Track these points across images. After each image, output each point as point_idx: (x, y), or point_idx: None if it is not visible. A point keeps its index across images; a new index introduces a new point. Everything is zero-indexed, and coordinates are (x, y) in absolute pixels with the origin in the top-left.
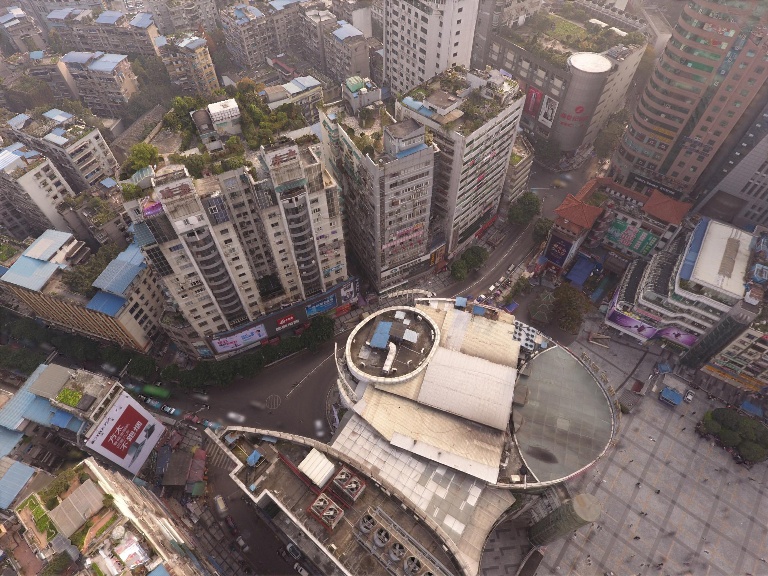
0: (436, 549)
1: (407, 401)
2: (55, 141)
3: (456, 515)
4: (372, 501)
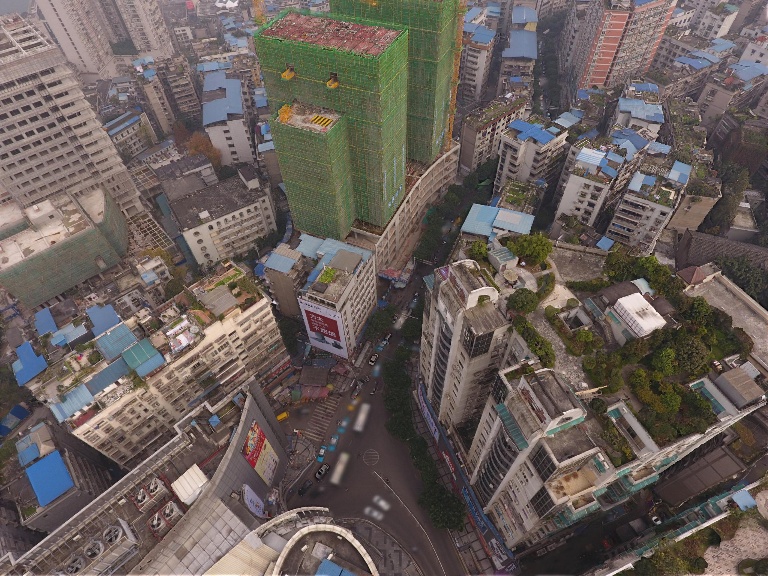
0: None
1: None
2: (633, 182)
3: None
4: (147, 545)
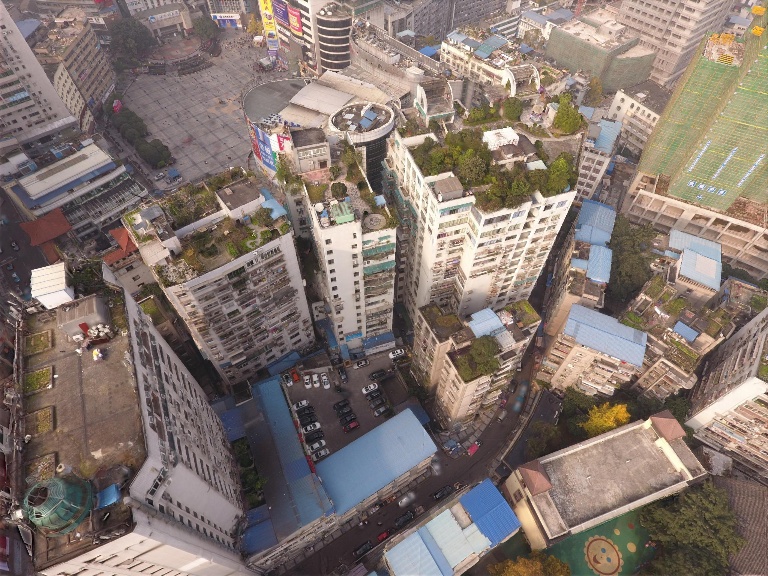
0: None
1: None
2: None
3: (350, 69)
4: None
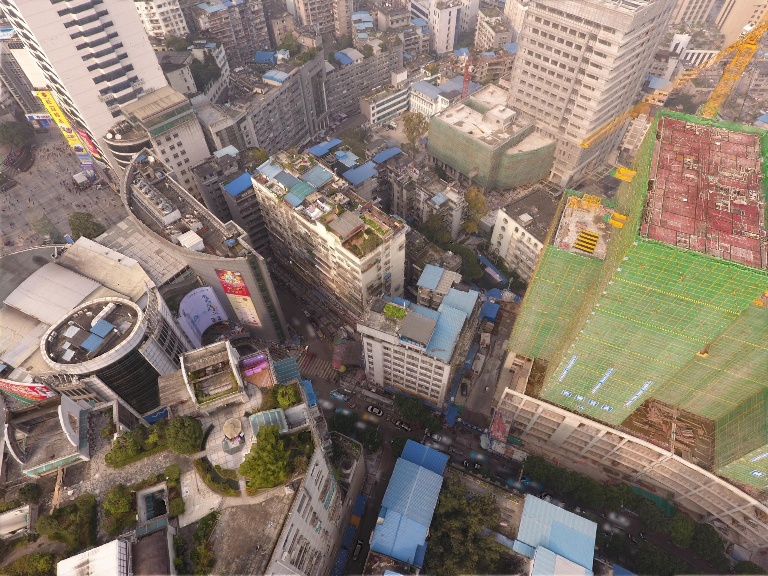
0: (138, 210)
1: (110, 288)
2: None
3: (119, 229)
4: None
